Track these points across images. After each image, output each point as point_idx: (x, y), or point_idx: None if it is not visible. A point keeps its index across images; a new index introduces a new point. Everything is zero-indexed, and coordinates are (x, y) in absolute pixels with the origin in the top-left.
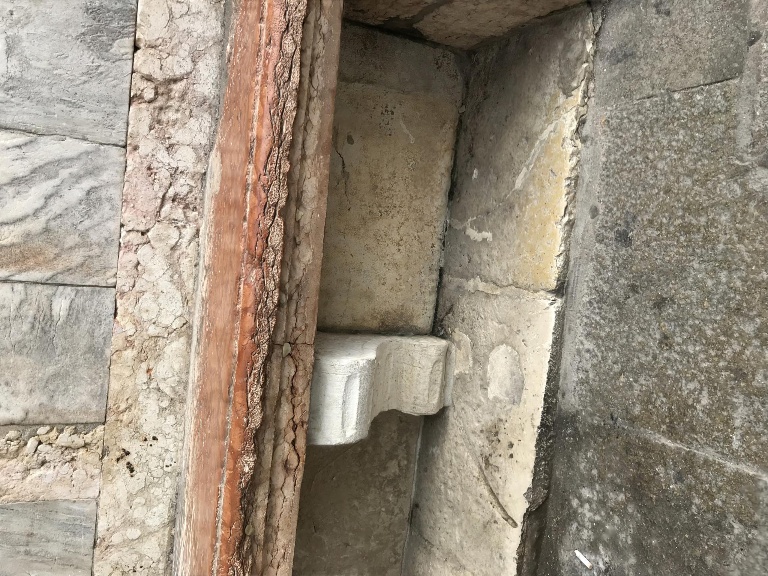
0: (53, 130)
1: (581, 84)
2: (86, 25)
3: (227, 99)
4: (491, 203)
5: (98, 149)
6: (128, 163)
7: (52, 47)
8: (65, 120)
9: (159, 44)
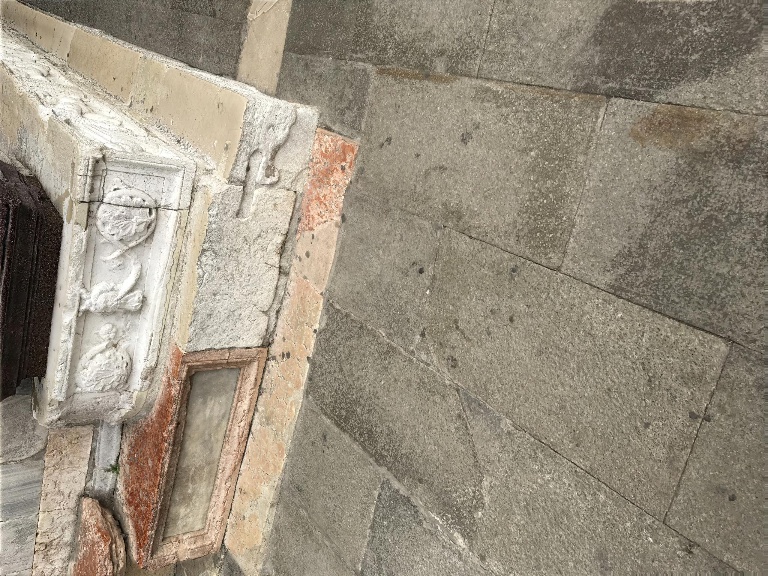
0: (1, 574)
1: (219, 568)
2: (16, 536)
3: (79, 572)
4: (192, 572)
5: (20, 573)
6: (33, 572)
7: (1, 549)
8: (6, 569)
9: (48, 530)
